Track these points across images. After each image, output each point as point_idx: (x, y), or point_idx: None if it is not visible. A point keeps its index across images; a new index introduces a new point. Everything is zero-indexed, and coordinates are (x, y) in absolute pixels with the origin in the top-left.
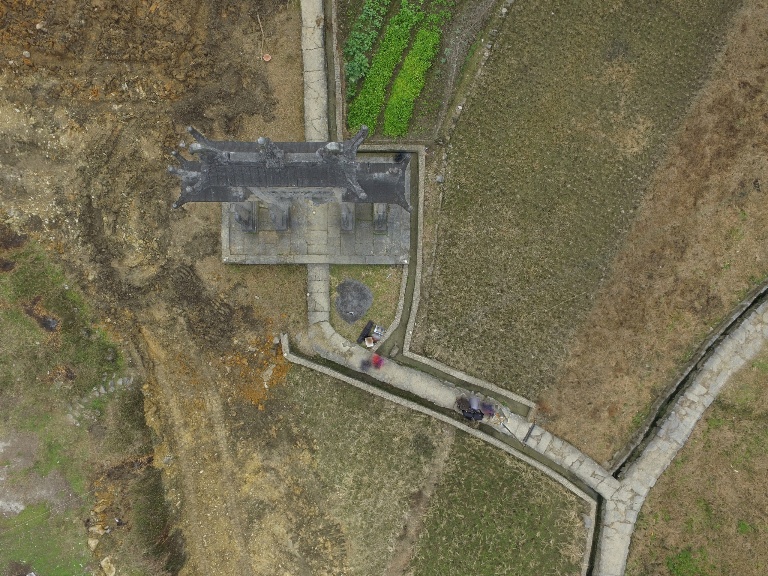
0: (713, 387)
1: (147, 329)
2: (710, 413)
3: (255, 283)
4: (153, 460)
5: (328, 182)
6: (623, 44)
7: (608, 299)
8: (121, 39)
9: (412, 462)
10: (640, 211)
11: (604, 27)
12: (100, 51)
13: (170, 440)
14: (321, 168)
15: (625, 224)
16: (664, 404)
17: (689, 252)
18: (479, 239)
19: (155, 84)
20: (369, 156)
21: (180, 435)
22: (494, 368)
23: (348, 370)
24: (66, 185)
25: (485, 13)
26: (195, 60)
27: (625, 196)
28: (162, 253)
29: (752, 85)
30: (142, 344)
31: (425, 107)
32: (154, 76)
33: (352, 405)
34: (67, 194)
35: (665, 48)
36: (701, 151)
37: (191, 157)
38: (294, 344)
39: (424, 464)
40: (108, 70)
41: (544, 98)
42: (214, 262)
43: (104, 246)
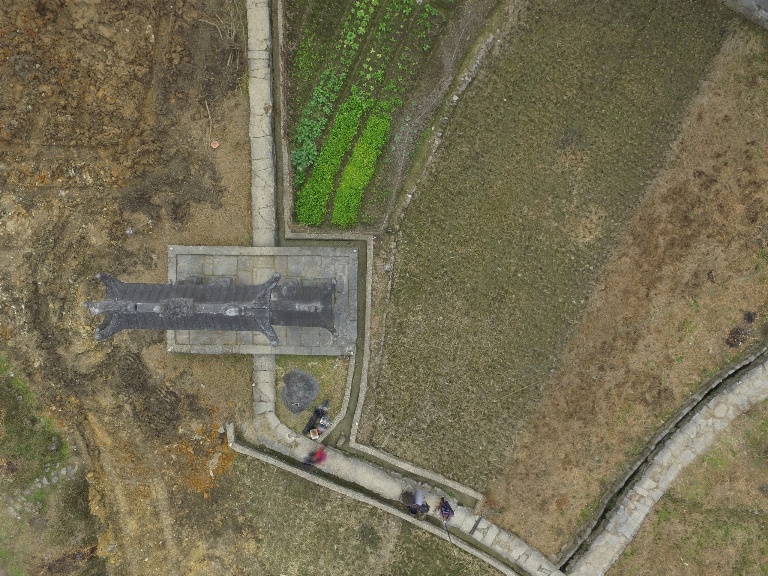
0: (663, 481)
1: (93, 416)
2: (660, 506)
3: (201, 371)
4: (97, 549)
5: (241, 327)
6: (576, 131)
7: (558, 390)
8: (68, 125)
9: (358, 552)
10: (591, 301)
11: (557, 114)
12: (47, 137)
13: (115, 527)
14: (231, 316)
15: (576, 315)
16: (614, 496)
17: (641, 344)
18: (428, 328)
19: (102, 170)
20: (317, 243)
21: (126, 522)
22: (442, 459)
23: (295, 459)
24: (13, 271)
25: (434, 103)
26: (142, 147)
27: (576, 286)
28: (109, 339)
29: (707, 174)
30: (88, 431)
31: (374, 195)
32: (101, 161)
33: (298, 494)
34: (14, 280)
35: (619, 136)
36: (654, 241)
37: (138, 244)
38: (240, 432)
39: (370, 555)
40: (55, 155)
41: (495, 186)
42: (160, 350)
43: (50, 332)
